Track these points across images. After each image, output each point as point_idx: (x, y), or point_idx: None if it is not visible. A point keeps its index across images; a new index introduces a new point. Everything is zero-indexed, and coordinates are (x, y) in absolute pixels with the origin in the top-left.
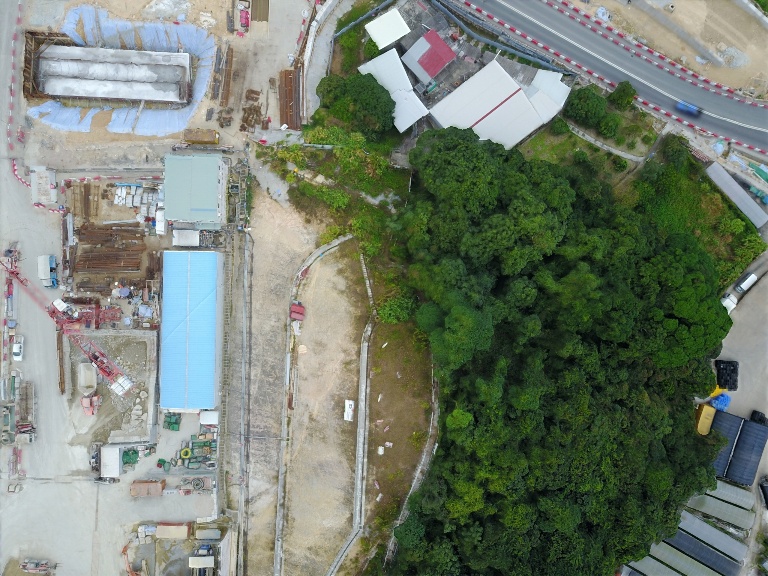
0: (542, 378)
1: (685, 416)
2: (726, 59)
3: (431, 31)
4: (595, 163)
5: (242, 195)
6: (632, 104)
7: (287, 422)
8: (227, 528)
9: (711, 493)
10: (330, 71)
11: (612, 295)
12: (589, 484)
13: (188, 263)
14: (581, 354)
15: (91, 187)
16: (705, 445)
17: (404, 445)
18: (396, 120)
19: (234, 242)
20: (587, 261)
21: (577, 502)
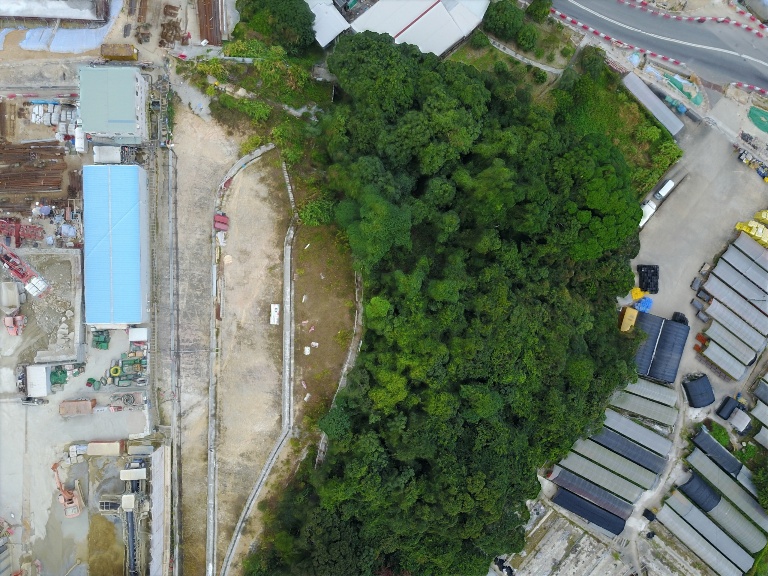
0: (464, 275)
1: (606, 313)
2: None
3: None
4: (513, 71)
5: (164, 111)
6: (550, 17)
7: (216, 333)
8: (160, 444)
9: (636, 392)
10: None
11: (526, 187)
12: (511, 375)
13: (108, 177)
14: (500, 250)
15: (7, 106)
16: (625, 340)
17: (330, 345)
18: (317, 34)
19: (158, 160)
20: (503, 158)
21: (500, 393)
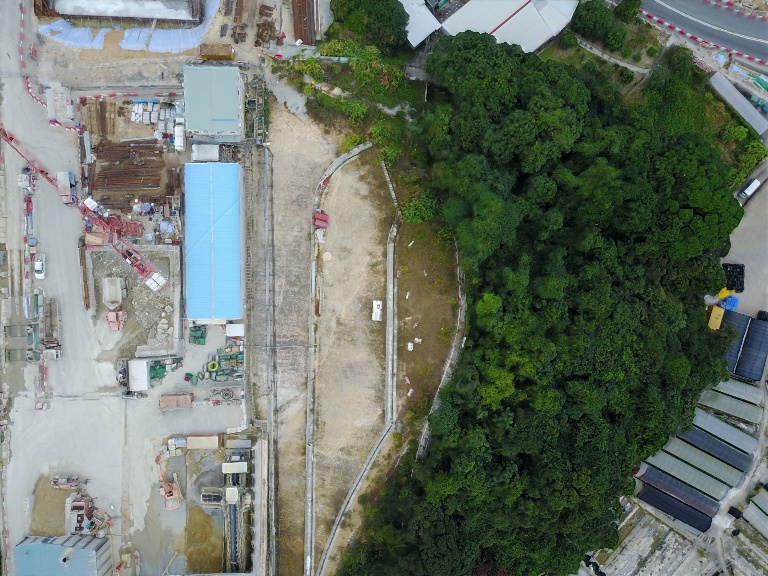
0: (564, 273)
1: (698, 312)
2: None
3: None
4: (605, 71)
5: (259, 110)
6: (637, 17)
7: (314, 329)
8: (256, 438)
9: (722, 390)
10: None
11: (630, 186)
12: (612, 372)
13: (210, 174)
14: (600, 248)
15: (107, 105)
16: (717, 338)
17: (433, 341)
18: (409, 34)
19: (253, 158)
20: (604, 157)
21: None
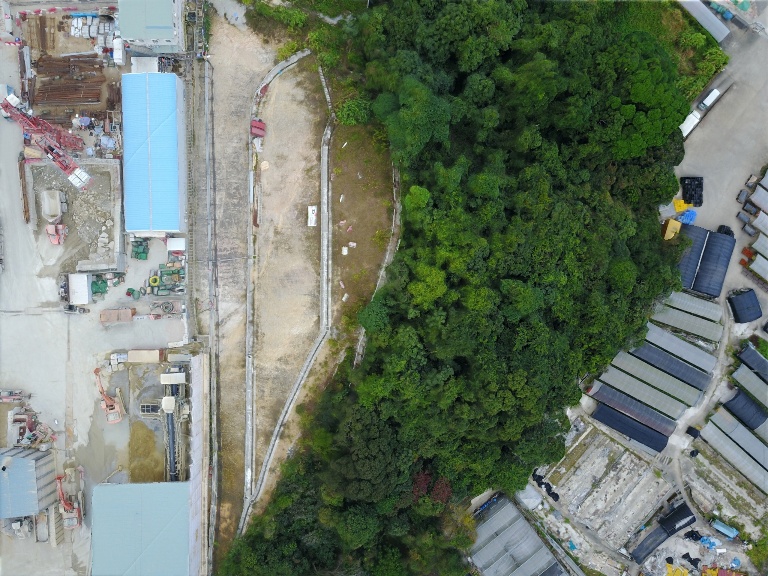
0: (503, 175)
1: (649, 221)
2: None
3: None
4: None
5: (200, 23)
6: None
7: (253, 240)
8: (199, 353)
9: (679, 306)
10: None
11: (568, 80)
12: (552, 276)
13: (146, 84)
14: (541, 149)
15: (47, 19)
16: (669, 247)
17: (367, 245)
18: None
19: (194, 72)
20: None
21: None
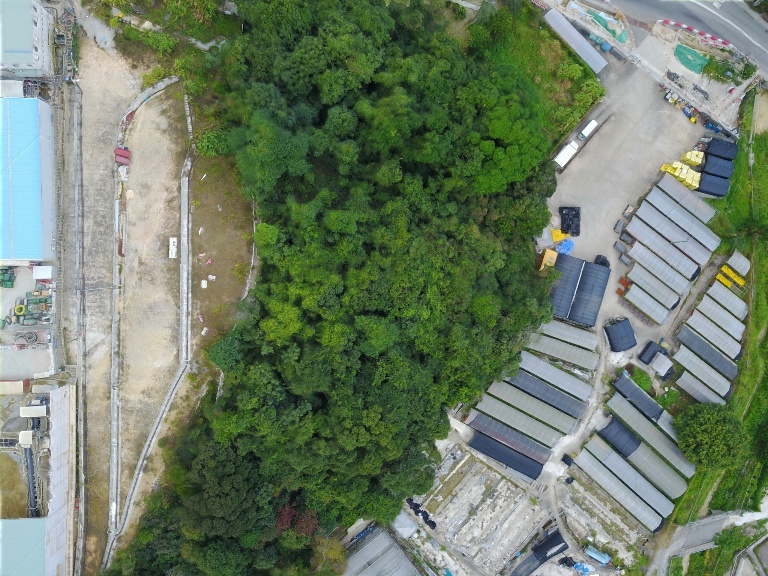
0: (366, 208)
1: (519, 252)
2: None
3: None
4: (427, 4)
5: (69, 46)
6: None
7: (119, 270)
8: None
9: (555, 335)
10: None
11: (426, 116)
12: (414, 310)
13: (7, 110)
14: (404, 183)
15: None
16: (538, 279)
17: (227, 278)
18: None
19: (64, 96)
20: (406, 88)
21: (402, 327)
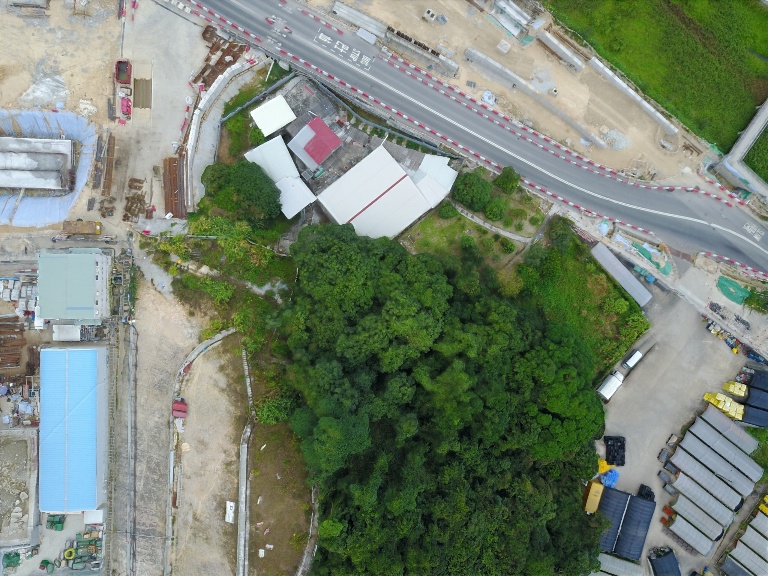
0: (423, 473)
1: (569, 499)
2: (609, 141)
3: (317, 118)
4: (479, 250)
5: (126, 286)
6: (519, 186)
7: (172, 521)
8: None
9: (601, 568)
10: (217, 156)
11: (485, 394)
12: None
13: (66, 362)
14: (460, 448)
15: None
16: (588, 528)
17: (285, 547)
18: (283, 207)
19: (119, 334)
20: (464, 357)
21: None
